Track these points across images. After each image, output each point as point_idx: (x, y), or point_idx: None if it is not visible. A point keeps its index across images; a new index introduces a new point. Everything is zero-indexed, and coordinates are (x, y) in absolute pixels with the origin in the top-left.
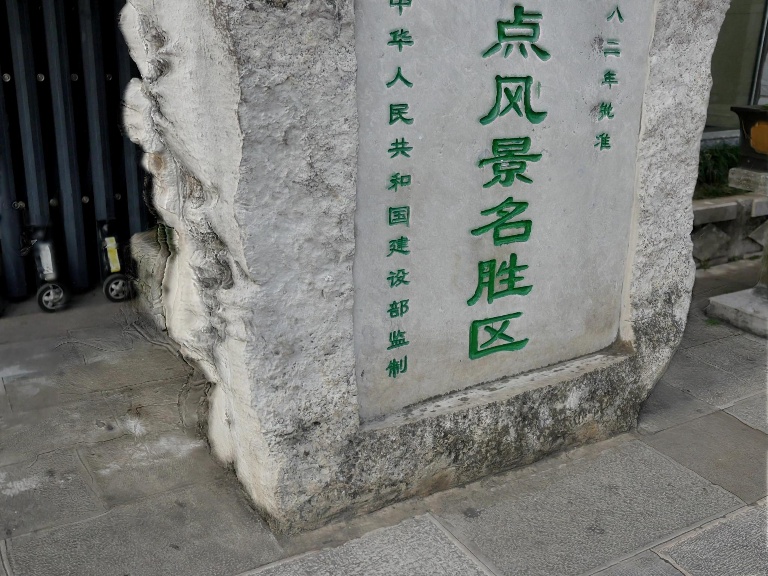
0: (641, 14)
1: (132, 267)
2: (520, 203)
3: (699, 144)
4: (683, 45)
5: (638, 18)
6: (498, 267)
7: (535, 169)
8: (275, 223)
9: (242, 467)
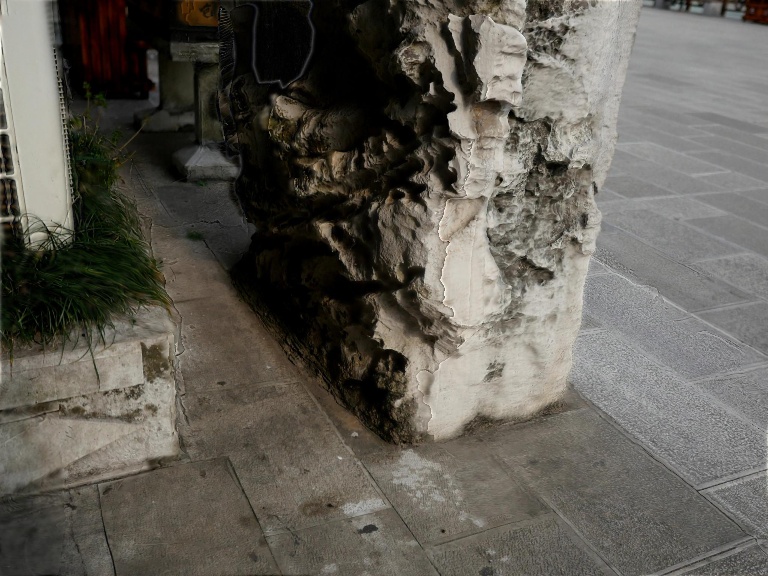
0: None
1: (56, 389)
2: None
3: None
4: None
5: None
6: None
7: None
8: None
9: (513, 398)
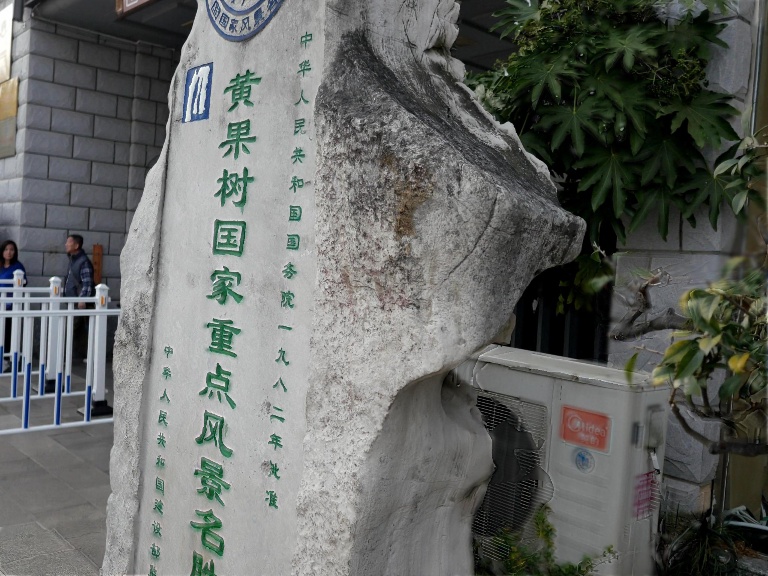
0: (302, 388)
1: None
2: (219, 519)
3: (351, 553)
4: (338, 430)
5: (299, 391)
6: (204, 564)
7: (226, 495)
8: (119, 458)
9: None
